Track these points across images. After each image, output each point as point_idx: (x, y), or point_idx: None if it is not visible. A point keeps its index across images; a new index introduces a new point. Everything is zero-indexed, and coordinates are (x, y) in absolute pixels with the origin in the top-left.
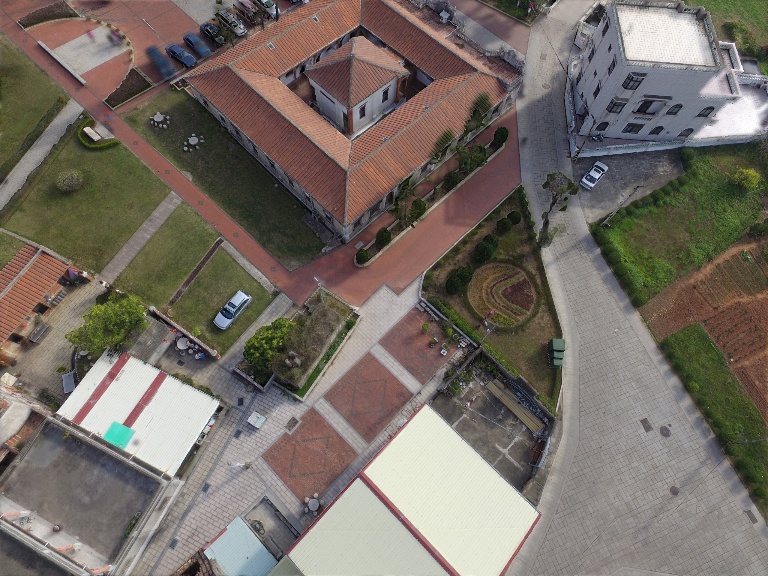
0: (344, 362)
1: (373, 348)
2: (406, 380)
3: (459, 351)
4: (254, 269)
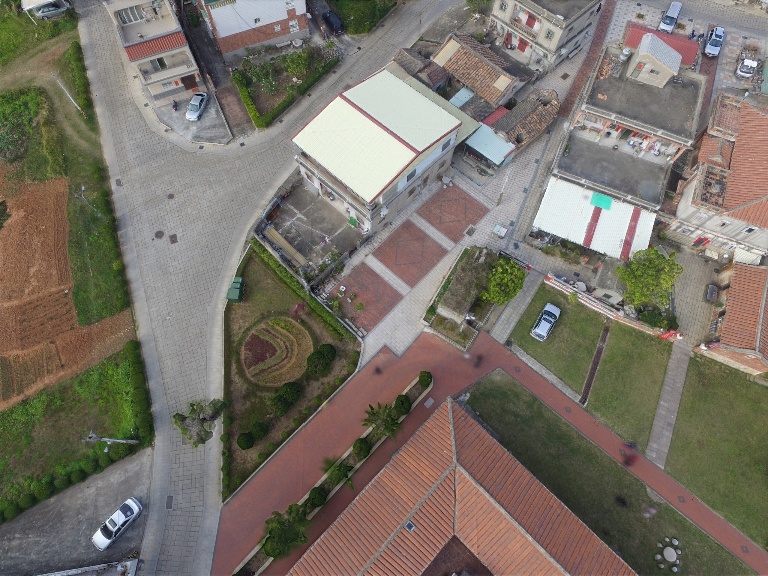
0: (434, 279)
1: (408, 292)
2: (378, 265)
3: (328, 291)
4: (537, 369)
